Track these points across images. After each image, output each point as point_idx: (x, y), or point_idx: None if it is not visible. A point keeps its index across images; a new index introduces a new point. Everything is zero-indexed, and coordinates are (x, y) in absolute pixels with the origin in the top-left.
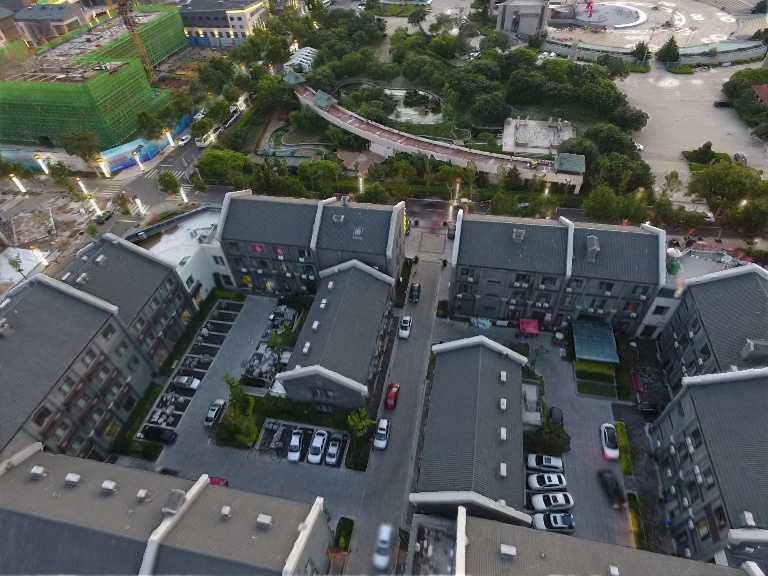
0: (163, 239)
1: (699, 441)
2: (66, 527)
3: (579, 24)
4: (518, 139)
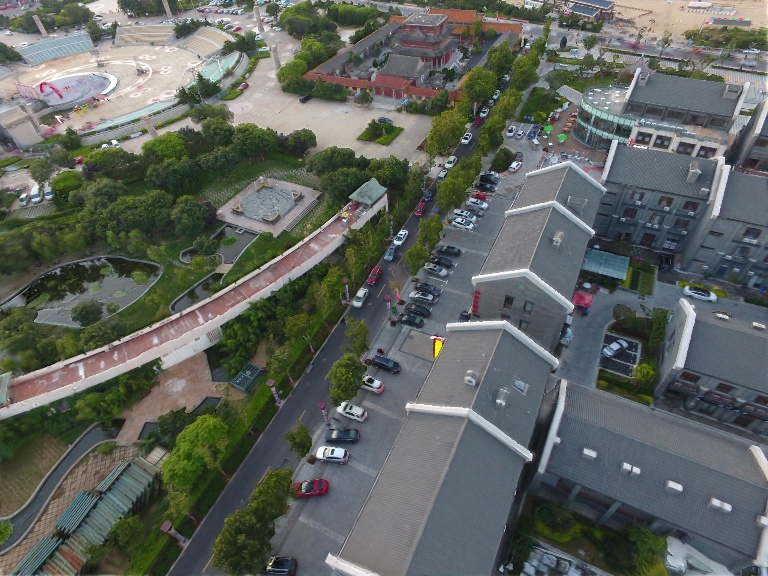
0: None
1: (757, 233)
2: None
3: (61, 109)
4: (265, 218)
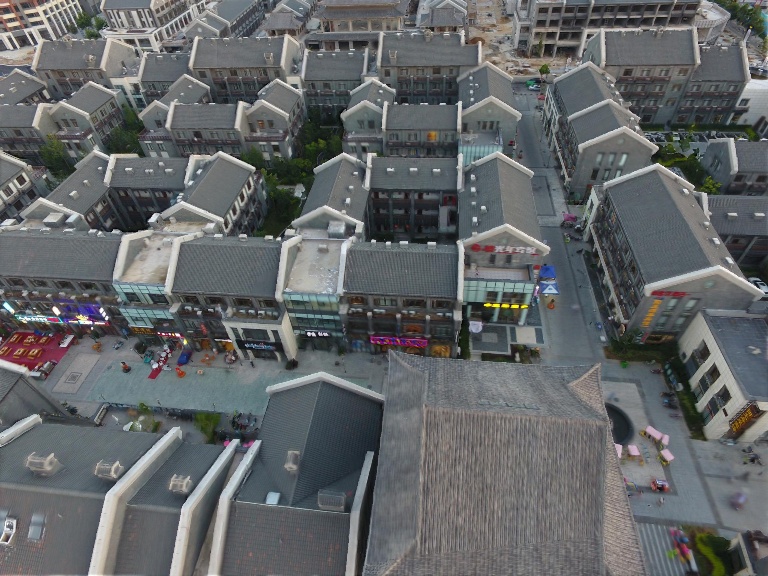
0: (766, 80)
1: None
2: (597, 86)
3: None
4: None
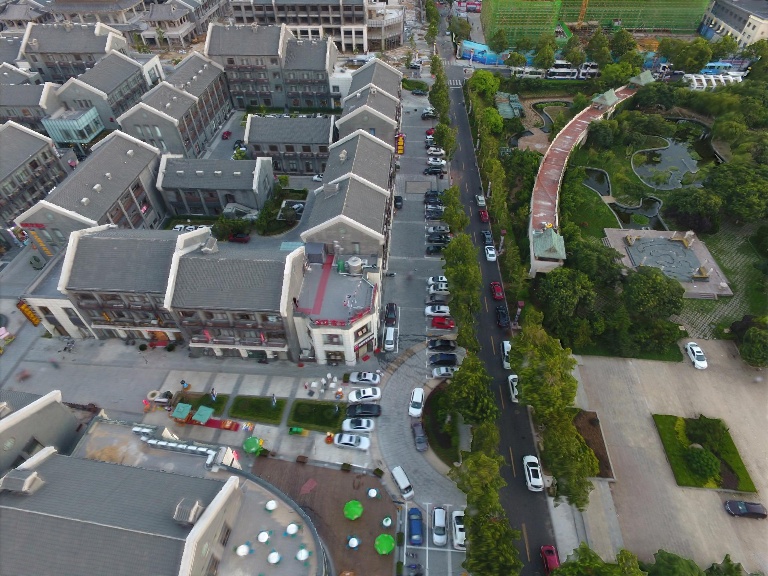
0: None
1: None
2: None
3: None
4: (637, 238)
